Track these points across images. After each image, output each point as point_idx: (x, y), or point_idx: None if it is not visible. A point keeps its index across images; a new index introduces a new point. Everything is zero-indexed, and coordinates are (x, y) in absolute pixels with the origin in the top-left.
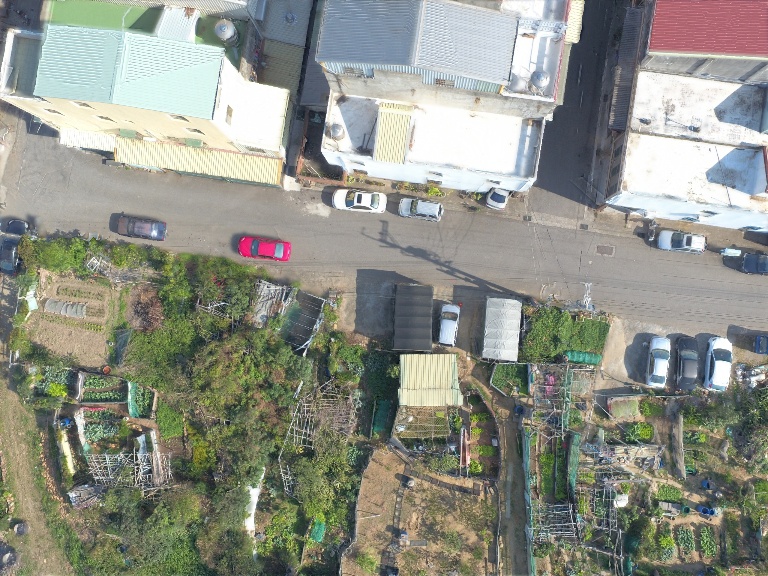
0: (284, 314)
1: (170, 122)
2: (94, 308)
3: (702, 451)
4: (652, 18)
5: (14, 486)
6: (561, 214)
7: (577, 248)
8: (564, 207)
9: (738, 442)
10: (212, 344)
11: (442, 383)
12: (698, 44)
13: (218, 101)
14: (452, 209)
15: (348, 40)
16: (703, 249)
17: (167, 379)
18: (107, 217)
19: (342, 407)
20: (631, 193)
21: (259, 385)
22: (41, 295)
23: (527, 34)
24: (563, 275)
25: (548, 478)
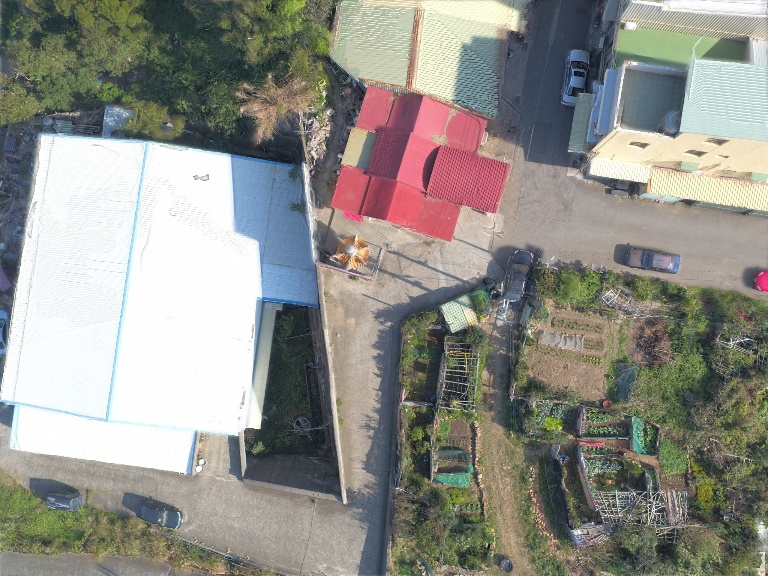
0: None
1: None
2: (592, 341)
3: None
4: None
5: (496, 521)
6: None
7: None
8: None
9: None
10: (734, 381)
11: None
12: None
13: None
14: None
15: None
16: None
17: (675, 415)
18: (611, 248)
19: None
20: None
21: None
22: (536, 327)
23: None
24: None
25: None
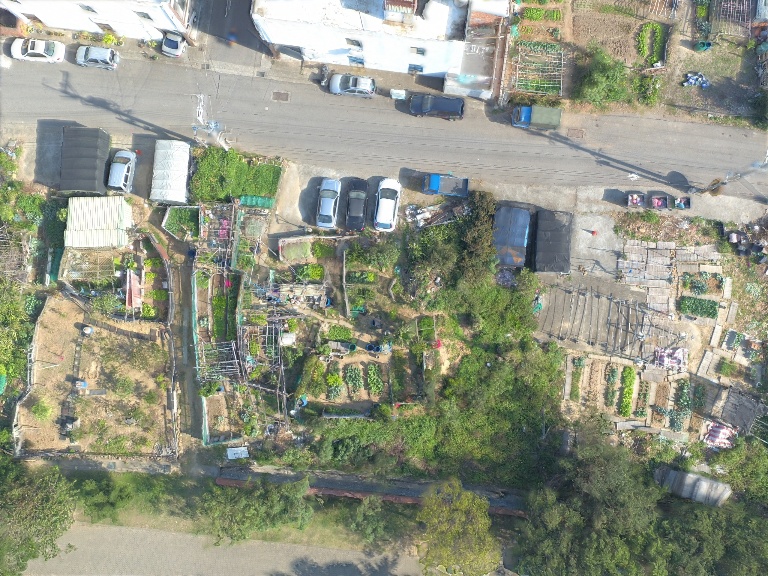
0: None
1: None
2: None
3: (370, 290)
4: None
5: None
6: (238, 62)
7: (253, 95)
8: (241, 55)
9: (404, 280)
10: None
11: (108, 224)
12: None
13: None
14: (131, 58)
15: None
16: (369, 90)
17: None
18: None
19: (14, 253)
20: (261, 16)
21: None
22: None
23: None
24: (239, 121)
25: (220, 320)
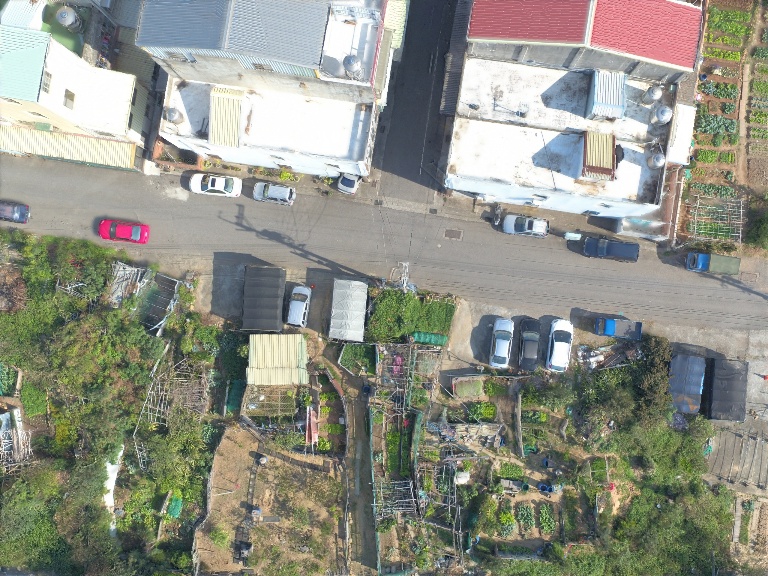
0: (140, 295)
1: (7, 105)
2: None
3: (542, 430)
4: (472, 6)
5: None
6: (411, 199)
7: (426, 232)
8: (414, 192)
9: (577, 421)
10: (71, 324)
11: (289, 362)
12: (513, 31)
13: (43, 84)
14: (306, 193)
15: (162, 25)
16: (544, 233)
17: (30, 358)
18: None
19: (195, 386)
20: (457, 176)
21: (117, 364)
22: None
23: (348, 21)
24: (412, 258)
25: (394, 456)
